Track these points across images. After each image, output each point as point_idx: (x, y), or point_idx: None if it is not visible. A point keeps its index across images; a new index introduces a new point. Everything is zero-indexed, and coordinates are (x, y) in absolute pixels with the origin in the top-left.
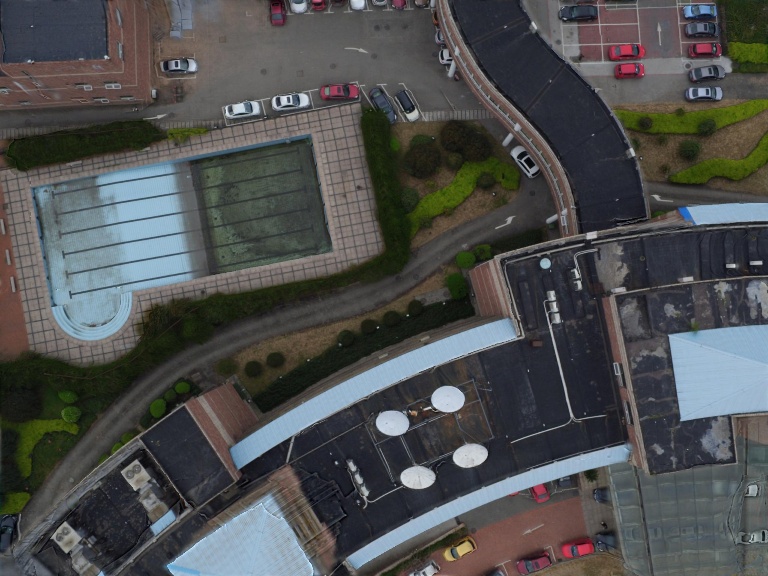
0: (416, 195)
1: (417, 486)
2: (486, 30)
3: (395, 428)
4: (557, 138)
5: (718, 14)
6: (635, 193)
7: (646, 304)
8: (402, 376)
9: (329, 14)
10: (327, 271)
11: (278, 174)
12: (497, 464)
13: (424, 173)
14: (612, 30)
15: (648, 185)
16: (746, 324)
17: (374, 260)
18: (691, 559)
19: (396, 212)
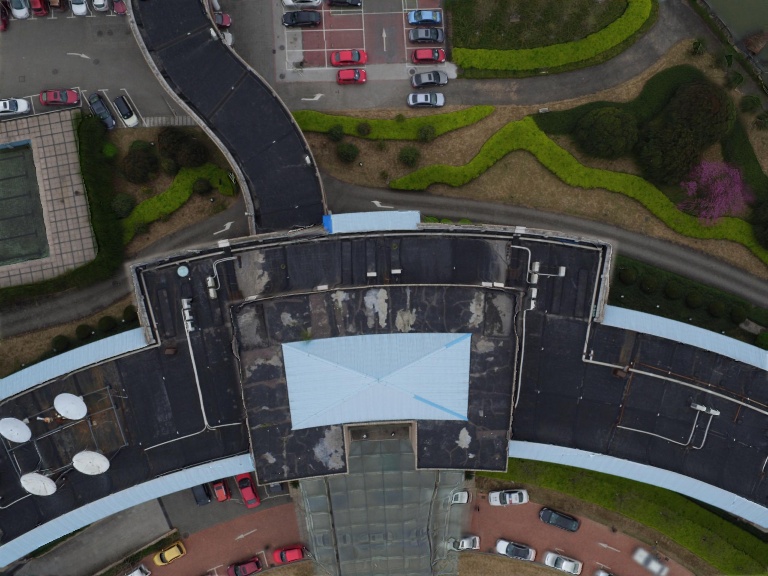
0: (130, 201)
1: (43, 493)
2: (171, 37)
3: (20, 435)
4: (239, 145)
5: (444, 20)
6: (316, 200)
7: (263, 313)
8: (33, 383)
9: (52, 19)
10: (43, 276)
11: (3, 179)
12: (131, 471)
13: (136, 179)
14: (336, 36)
15: (368, 191)
16: (363, 333)
17: (86, 265)
18: (381, 566)
19: (102, 218)
